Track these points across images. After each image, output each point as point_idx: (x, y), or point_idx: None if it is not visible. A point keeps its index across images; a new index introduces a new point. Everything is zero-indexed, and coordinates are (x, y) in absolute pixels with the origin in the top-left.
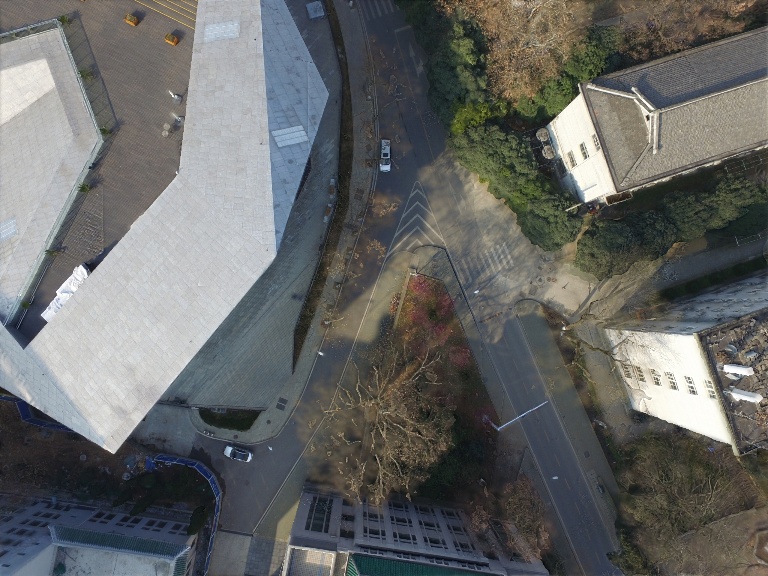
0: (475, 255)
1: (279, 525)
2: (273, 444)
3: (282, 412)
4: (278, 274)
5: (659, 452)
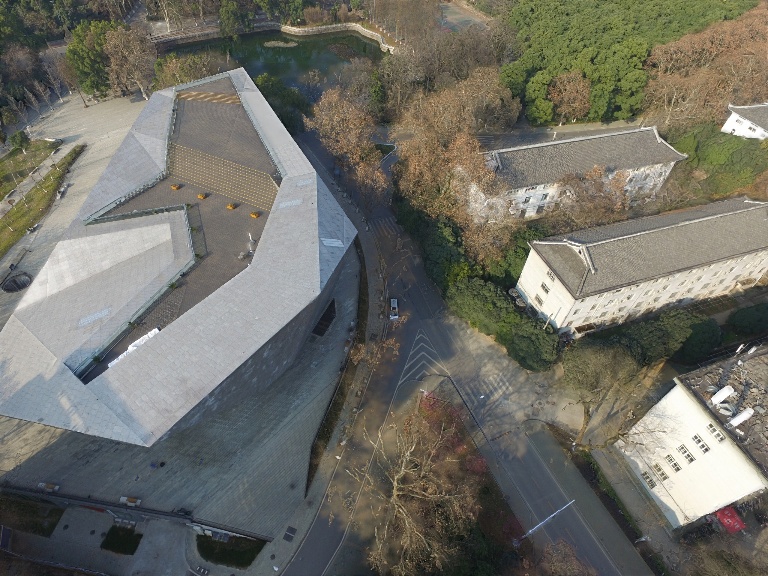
0: (477, 382)
1: None
2: None
3: (289, 544)
4: (302, 392)
5: (714, 552)
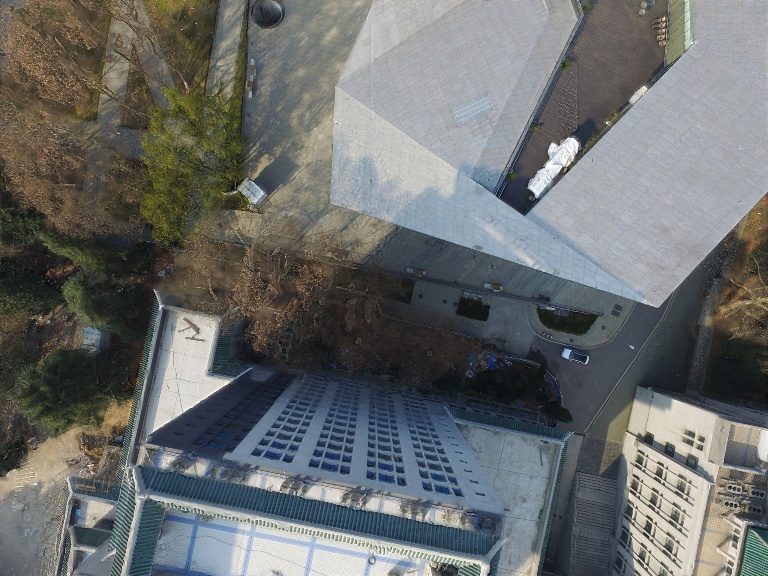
0: None
1: (610, 426)
2: (606, 349)
3: (617, 318)
4: None
5: None
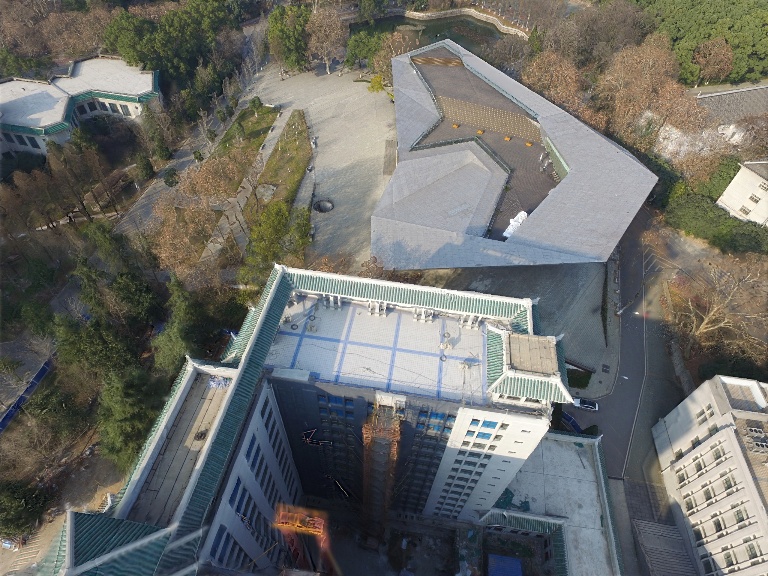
0: (704, 273)
1: (644, 469)
2: (610, 400)
3: (608, 375)
4: (581, 276)
5: None
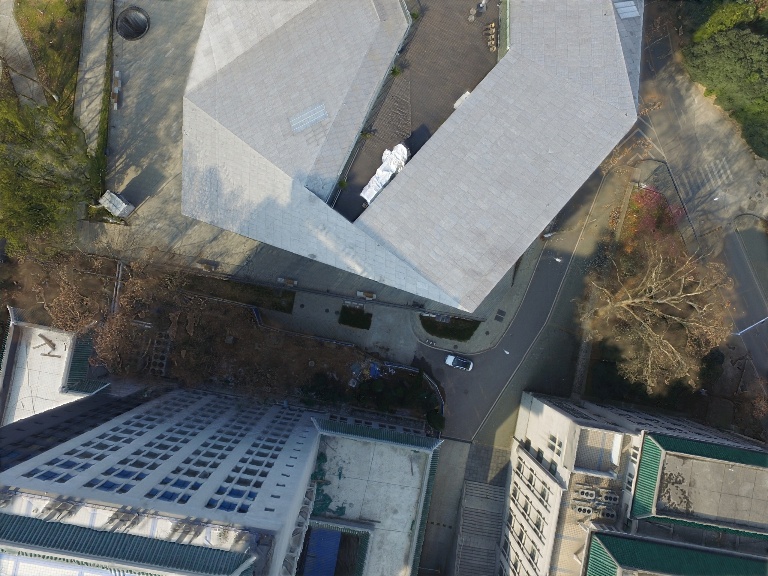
0: (695, 170)
1: (497, 433)
2: (491, 355)
3: (500, 324)
4: None
5: None
